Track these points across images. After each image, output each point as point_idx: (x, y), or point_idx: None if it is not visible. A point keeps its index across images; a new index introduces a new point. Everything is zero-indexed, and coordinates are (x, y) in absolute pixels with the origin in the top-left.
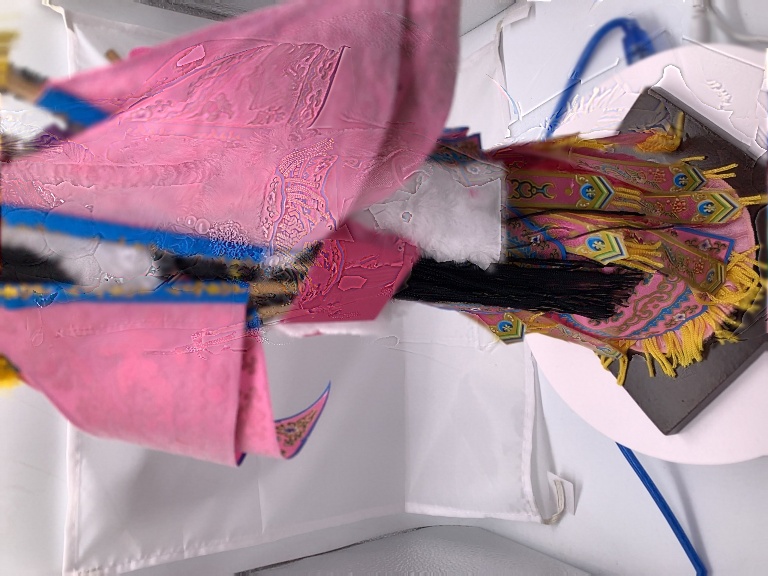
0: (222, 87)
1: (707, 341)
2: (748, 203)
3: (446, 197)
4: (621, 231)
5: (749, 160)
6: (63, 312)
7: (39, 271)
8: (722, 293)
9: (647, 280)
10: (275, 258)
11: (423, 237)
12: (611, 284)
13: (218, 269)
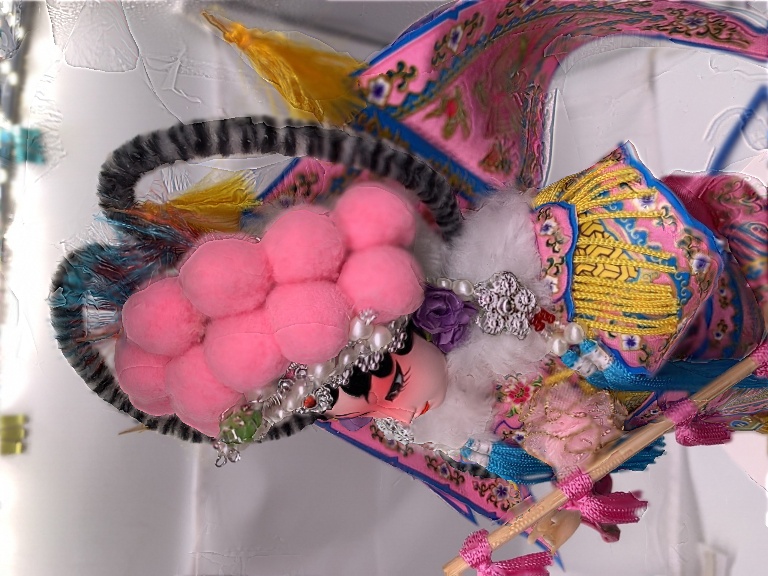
0: (462, 74)
1: None
2: None
3: None
4: None
5: None
6: None
7: (252, 322)
8: None
9: None
10: (577, 326)
11: None
12: None
13: None
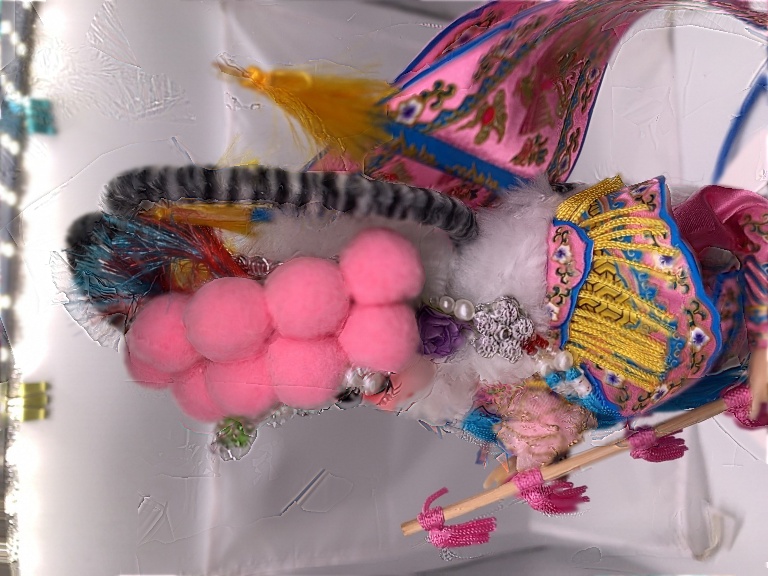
0: (504, 80)
1: None
2: None
3: None
4: None
5: None
6: (169, 555)
7: (253, 373)
8: None
9: None
10: (568, 355)
11: None
12: None
13: None
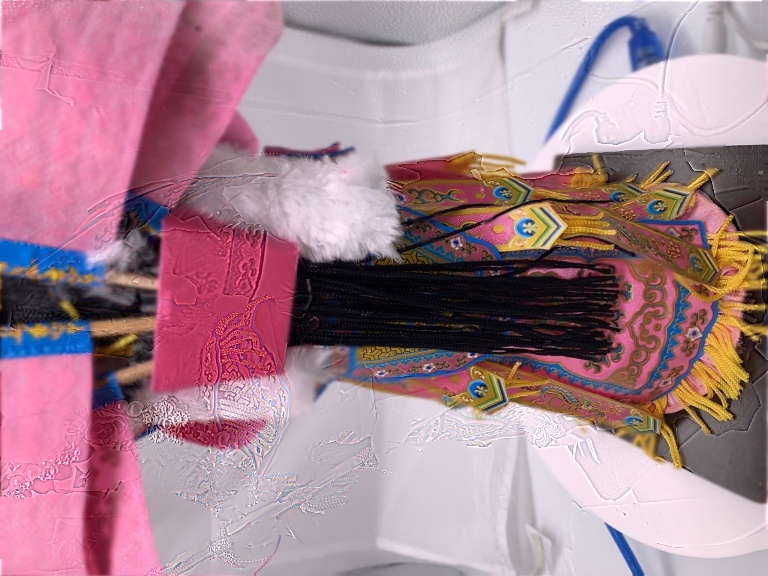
0: None
1: (742, 350)
2: (698, 185)
3: (314, 176)
4: (545, 201)
5: (677, 151)
6: None
7: None
8: (724, 282)
9: (627, 293)
10: (224, 434)
11: (300, 227)
12: (580, 296)
13: (170, 478)
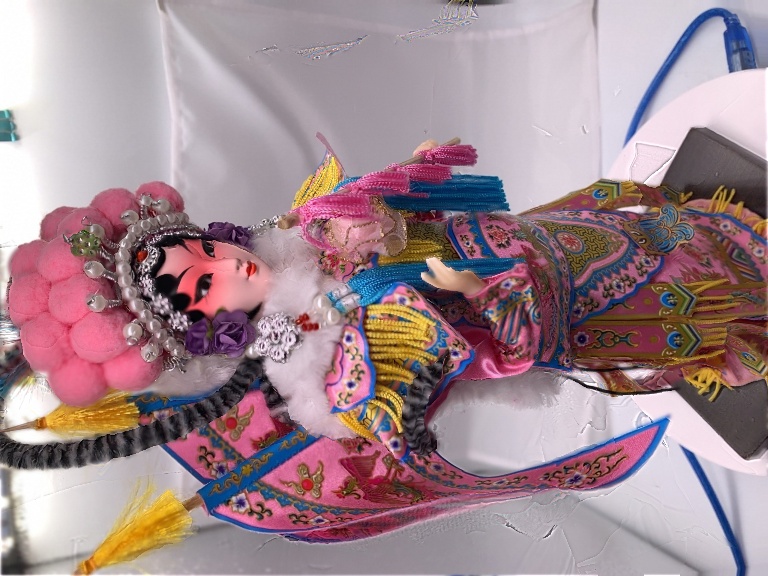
0: None
1: None
2: None
3: None
4: None
5: None
6: None
7: None
8: None
9: None
10: None
11: None
12: None
13: None
